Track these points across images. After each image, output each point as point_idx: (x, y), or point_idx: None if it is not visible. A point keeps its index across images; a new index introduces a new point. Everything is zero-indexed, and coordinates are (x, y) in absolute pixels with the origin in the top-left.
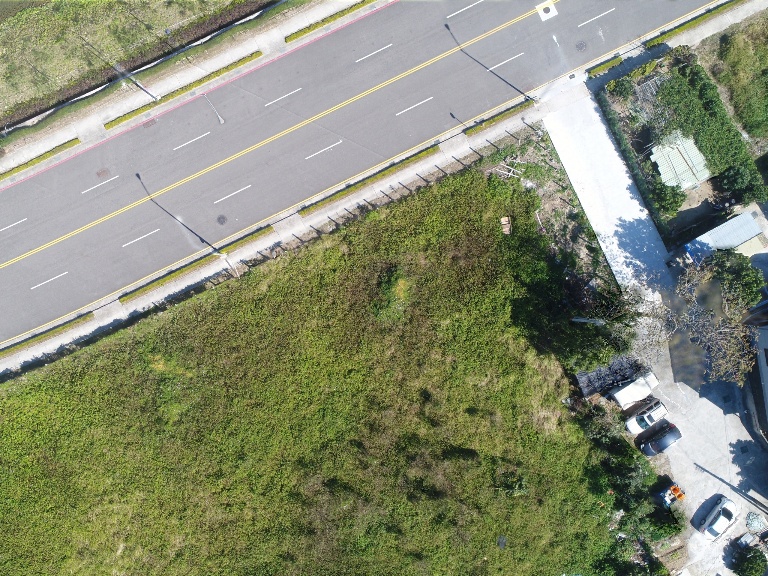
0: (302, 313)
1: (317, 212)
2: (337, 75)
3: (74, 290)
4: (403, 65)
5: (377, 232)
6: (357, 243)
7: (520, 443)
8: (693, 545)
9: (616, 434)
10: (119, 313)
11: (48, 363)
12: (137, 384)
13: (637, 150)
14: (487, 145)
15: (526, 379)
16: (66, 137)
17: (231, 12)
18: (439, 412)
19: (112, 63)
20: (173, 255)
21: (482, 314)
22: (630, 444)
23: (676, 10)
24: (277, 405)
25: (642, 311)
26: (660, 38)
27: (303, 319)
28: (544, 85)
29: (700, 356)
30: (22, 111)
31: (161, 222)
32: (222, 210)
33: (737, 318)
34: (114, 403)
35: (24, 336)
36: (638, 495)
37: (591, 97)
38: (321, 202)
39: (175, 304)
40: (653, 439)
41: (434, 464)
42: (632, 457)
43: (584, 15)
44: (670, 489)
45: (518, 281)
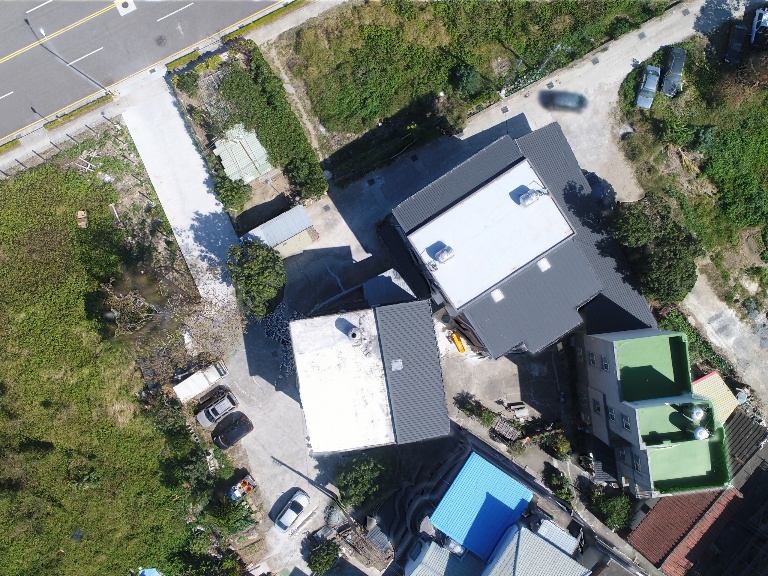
0: None
1: None
2: None
3: None
4: None
5: None
6: None
7: (96, 436)
8: (271, 538)
9: (172, 427)
10: None
11: None
12: None
13: None
14: (67, 139)
15: (100, 372)
16: None
17: None
18: (16, 405)
19: None
20: None
21: (57, 307)
22: (207, 437)
23: (254, 4)
24: None
25: None
26: (236, 32)
27: None
28: (124, 79)
29: (275, 350)
30: None
31: None
32: None
33: (260, 311)
34: None
35: None
36: (203, 488)
37: (170, 91)
38: None
39: None
40: (223, 432)
41: (11, 457)
42: (197, 450)
43: (162, 10)
44: (241, 482)
45: (89, 275)
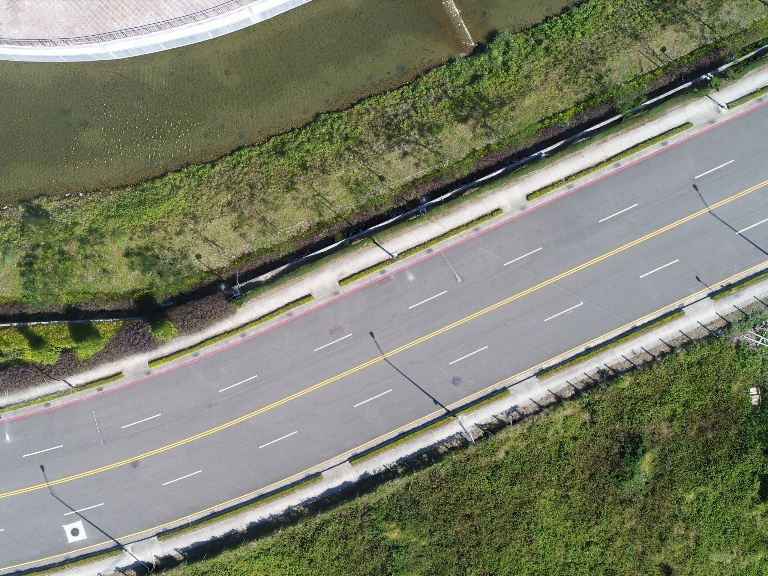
0: (540, 481)
1: (555, 376)
2: (579, 235)
3: (303, 450)
4: (649, 226)
5: (620, 400)
6: (601, 412)
7: None
8: None
9: None
10: (349, 475)
11: (275, 525)
12: (366, 549)
13: None
14: (734, 311)
15: None
16: (299, 293)
17: (470, 167)
18: None
19: (344, 215)
20: (405, 416)
21: (729, 488)
22: None
23: None
24: (511, 575)
25: None
26: None
27: (541, 488)
28: None
29: None
30: (252, 263)
31: (394, 382)
32: (457, 371)
33: None
34: (344, 569)
35: (250, 496)
36: None
37: None
38: (561, 366)
39: (414, 473)
40: None
41: None
42: None
43: None
44: None
45: None
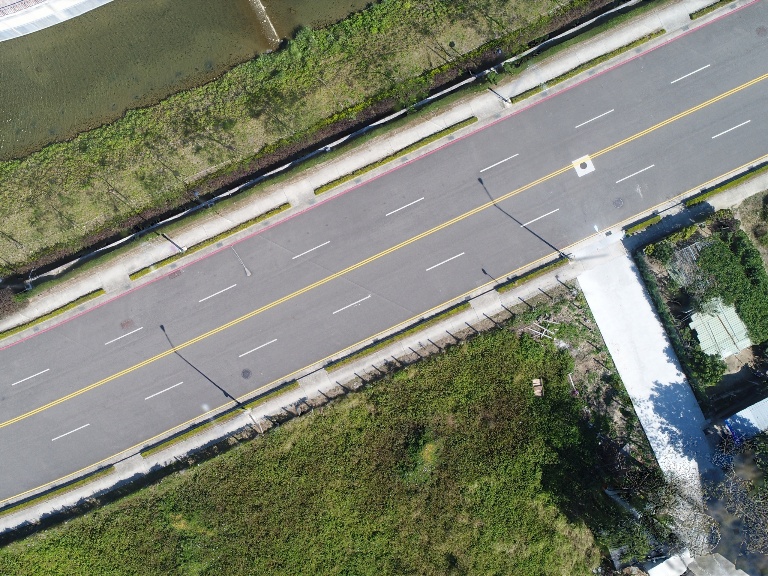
0: (326, 472)
1: (344, 368)
2: (367, 228)
3: (95, 442)
4: (434, 219)
5: (405, 392)
6: (384, 404)
7: None
8: None
9: None
10: (140, 467)
11: (68, 516)
12: (157, 540)
13: (675, 312)
14: (519, 303)
15: (556, 547)
16: (91, 287)
17: (260, 162)
18: None
19: (138, 210)
20: (196, 409)
21: (511, 478)
22: None
23: (718, 167)
24: (299, 565)
25: (684, 520)
26: (701, 197)
27: (327, 479)
28: (579, 242)
29: (737, 527)
30: (47, 258)
31: (185, 375)
32: (247, 364)
33: None
34: (133, 560)
35: (44, 488)
36: None
37: (628, 256)
38: (348, 358)
39: (198, 464)
40: None
41: None
42: None
43: (622, 171)
44: None
45: (549, 447)
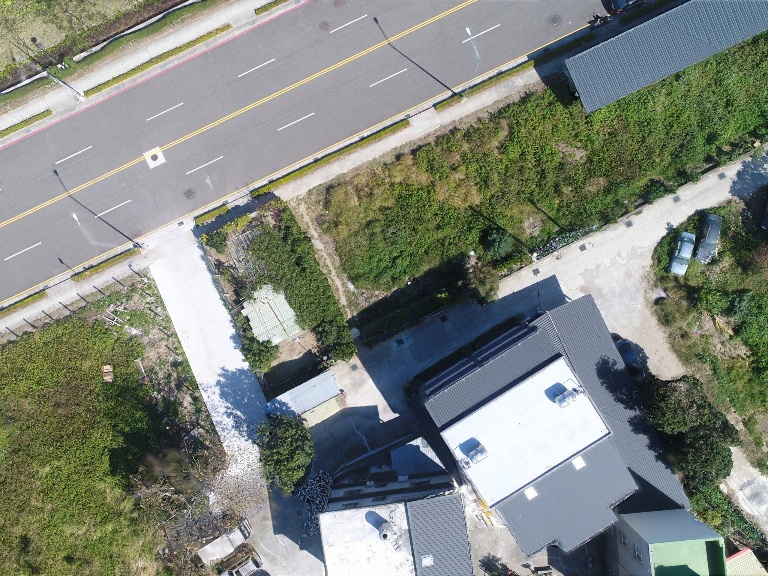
0: None
1: None
2: None
3: None
4: (11, 210)
5: None
6: None
7: None
8: None
9: None
10: None
11: None
12: None
13: None
14: (94, 291)
15: (123, 529)
16: None
17: None
18: (38, 559)
19: None
20: None
21: (81, 462)
22: None
23: (284, 159)
24: None
25: None
26: (265, 188)
27: None
28: (152, 232)
29: (300, 508)
30: None
31: None
32: None
33: (287, 489)
34: None
35: None
36: None
37: (198, 245)
38: None
39: None
40: None
41: None
42: None
43: (192, 163)
44: None
45: (114, 431)
